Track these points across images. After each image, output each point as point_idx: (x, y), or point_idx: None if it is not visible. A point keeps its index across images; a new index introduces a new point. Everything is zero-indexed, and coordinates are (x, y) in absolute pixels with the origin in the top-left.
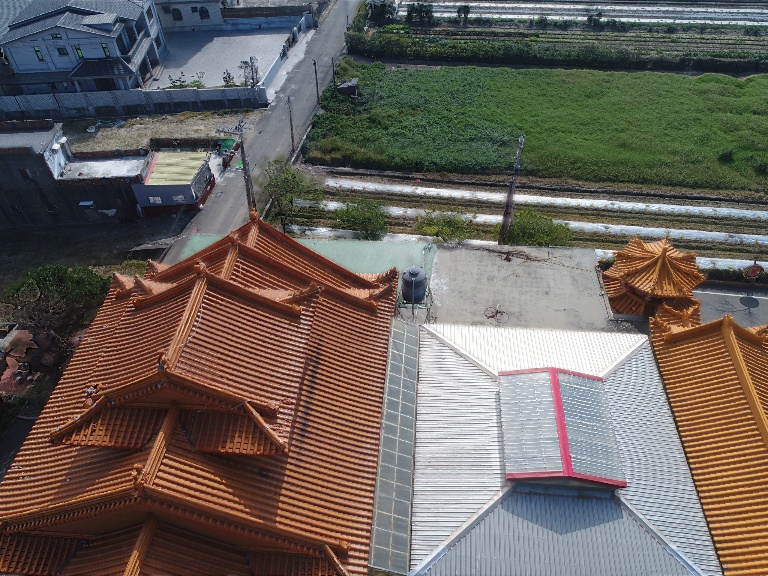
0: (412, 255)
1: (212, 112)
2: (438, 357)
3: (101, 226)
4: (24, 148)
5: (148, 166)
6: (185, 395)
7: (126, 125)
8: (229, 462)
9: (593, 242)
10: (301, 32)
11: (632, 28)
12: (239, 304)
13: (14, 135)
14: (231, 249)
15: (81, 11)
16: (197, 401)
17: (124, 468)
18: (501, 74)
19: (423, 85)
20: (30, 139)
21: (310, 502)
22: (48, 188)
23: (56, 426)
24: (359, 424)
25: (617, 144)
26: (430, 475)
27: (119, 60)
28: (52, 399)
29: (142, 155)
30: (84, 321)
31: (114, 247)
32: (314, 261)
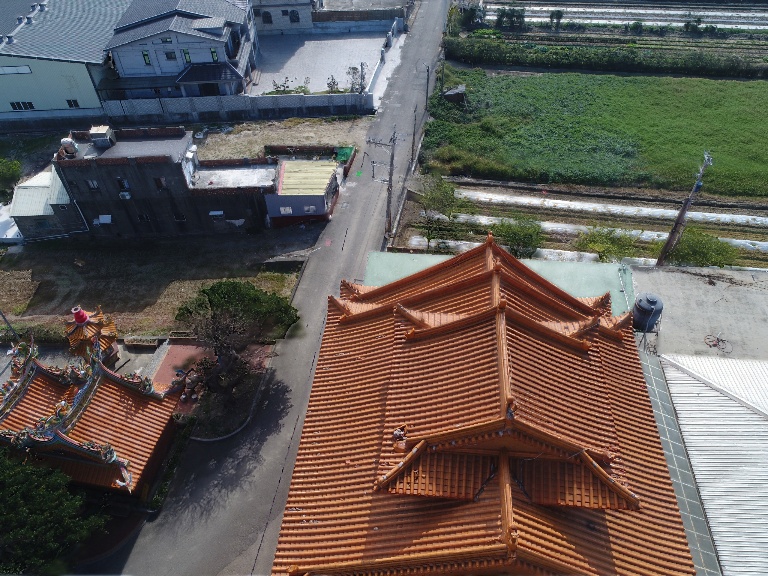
0: (608, 277)
1: (319, 119)
2: (691, 392)
3: (227, 236)
4: (163, 157)
5: (278, 175)
6: (526, 443)
7: (234, 131)
8: (561, 514)
9: (742, 259)
10: (393, 36)
11: (731, 35)
12: (534, 340)
13: (147, 143)
14: (497, 277)
15: (189, 15)
16: (531, 449)
17: (460, 521)
18: (608, 82)
19: (530, 92)
20: (164, 147)
21: (638, 557)
22: (180, 197)
23: (325, 464)
24: (648, 468)
25: (747, 156)
26: (727, 524)
27: (227, 65)
28: (306, 433)
29: (269, 164)
30: (259, 340)
31: (245, 258)
32: (539, 286)
